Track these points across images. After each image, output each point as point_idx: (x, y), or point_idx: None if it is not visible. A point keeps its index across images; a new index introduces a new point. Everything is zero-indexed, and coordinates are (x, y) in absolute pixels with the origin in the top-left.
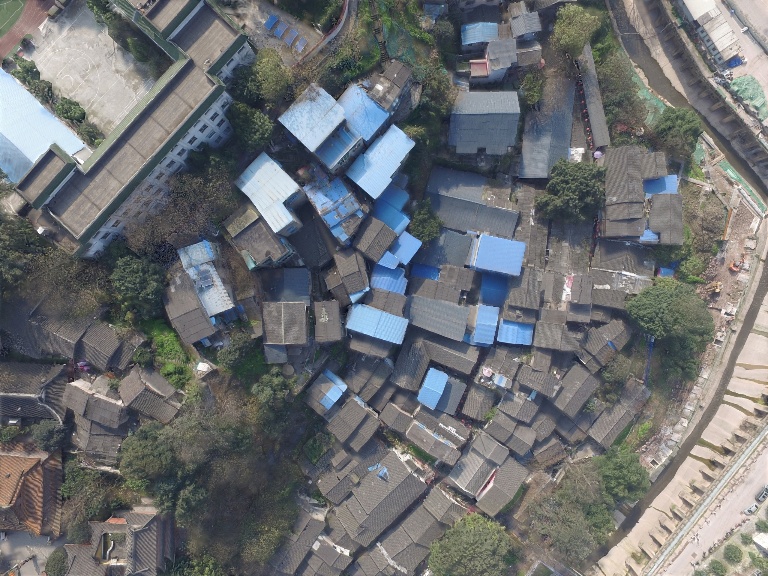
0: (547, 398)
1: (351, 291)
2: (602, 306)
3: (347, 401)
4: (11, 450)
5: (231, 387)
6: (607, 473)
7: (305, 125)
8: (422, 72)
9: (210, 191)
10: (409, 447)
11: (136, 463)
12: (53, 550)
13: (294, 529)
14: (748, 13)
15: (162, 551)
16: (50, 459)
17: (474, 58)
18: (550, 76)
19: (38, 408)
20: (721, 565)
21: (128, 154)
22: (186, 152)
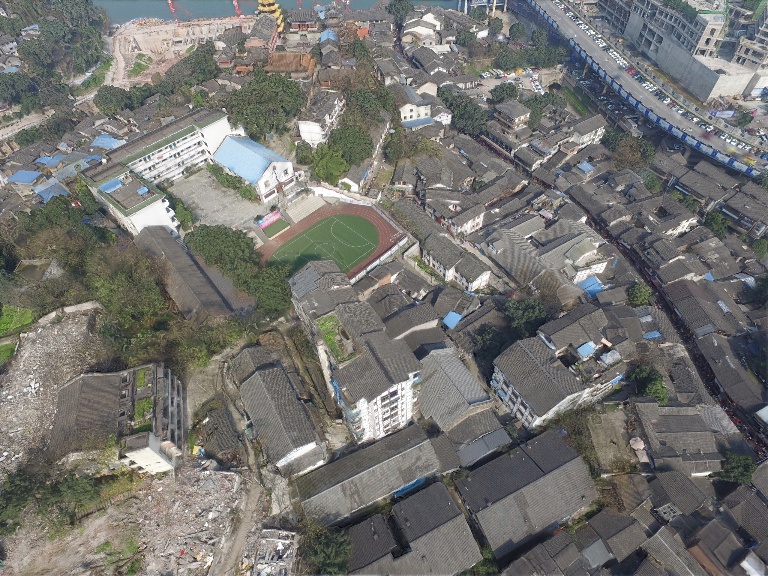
0: None
1: None
2: None
3: None
4: None
5: None
6: (35, 131)
7: None
8: None
9: None
10: None
11: (201, 56)
12: None
13: None
14: None
15: None
16: None
17: None
18: None
19: None
20: (4, 118)
21: (169, 134)
22: None
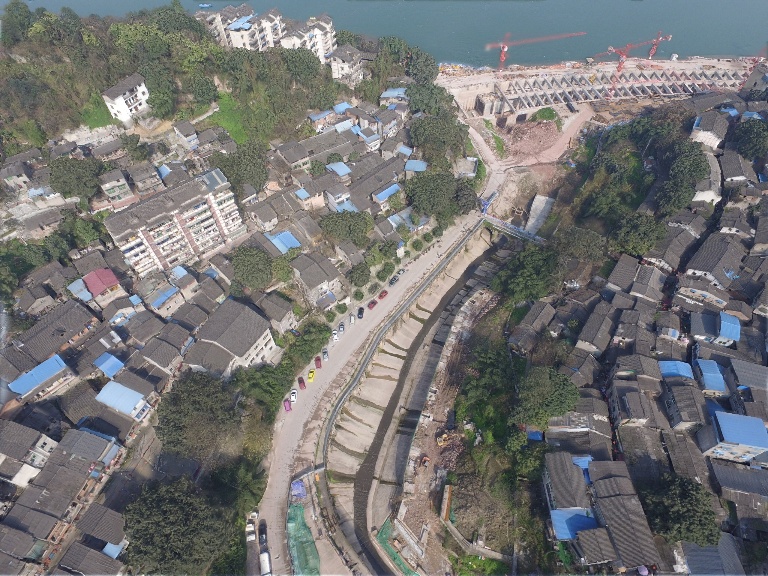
0: None
1: None
2: None
3: None
4: None
5: None
6: None
7: None
8: None
9: None
10: None
11: None
12: None
13: None
14: None
15: None
16: None
17: None
18: None
19: None
20: (429, 239)
21: None
22: None
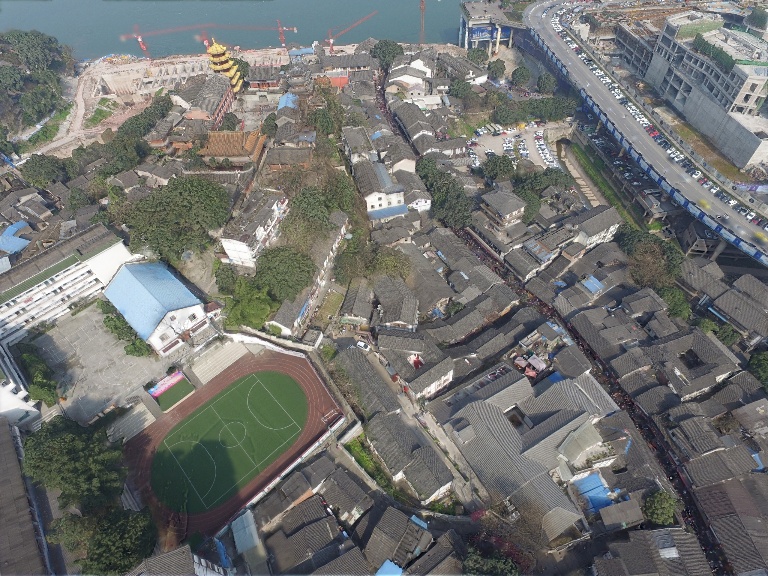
0: None
1: None
2: None
3: None
4: None
5: None
6: None
7: None
8: None
9: None
10: None
11: (118, 141)
12: None
13: None
14: None
15: None
16: None
17: None
18: None
19: None
20: None
21: (45, 266)
22: None
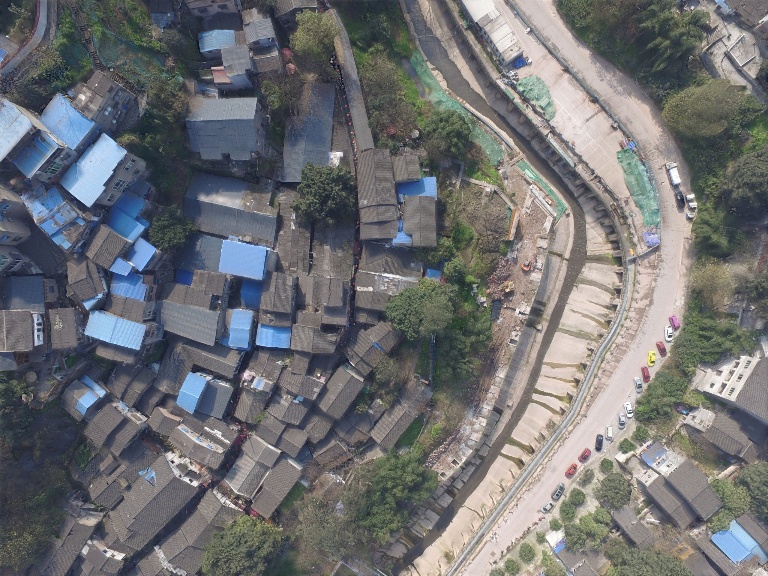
0: None
1: (83, 298)
2: (366, 308)
3: None
4: None
5: None
6: (382, 474)
7: None
8: (148, 80)
9: None
10: None
11: None
12: None
13: (60, 534)
14: (531, 14)
15: None
16: None
17: (217, 65)
18: (308, 81)
19: None
20: (513, 563)
21: None
22: None
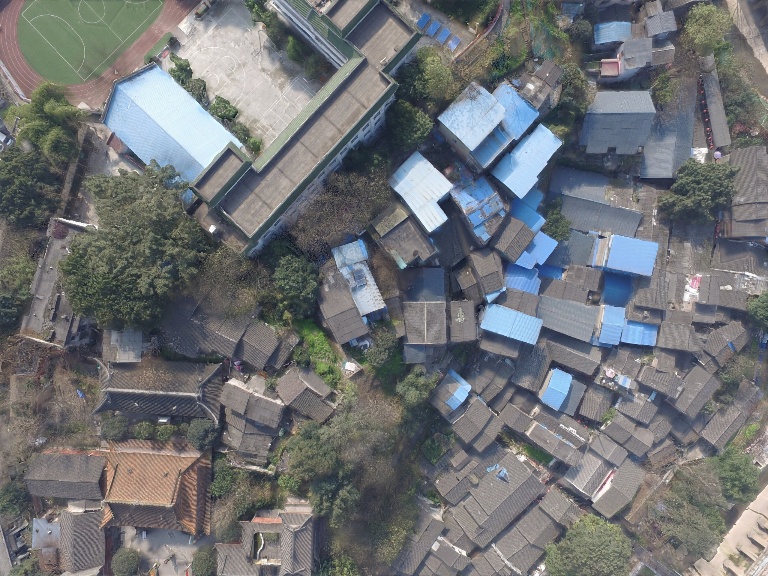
0: (665, 399)
1: (488, 291)
2: (723, 307)
3: (471, 401)
4: (161, 449)
5: (373, 387)
6: (723, 475)
7: (465, 124)
8: None
9: (373, 190)
10: (523, 448)
11: (308, 463)
12: (192, 549)
13: (415, 529)
14: None
15: (312, 551)
16: (201, 458)
17: (604, 57)
18: (673, 76)
19: (194, 407)
20: None
21: (300, 153)
22: (346, 151)
